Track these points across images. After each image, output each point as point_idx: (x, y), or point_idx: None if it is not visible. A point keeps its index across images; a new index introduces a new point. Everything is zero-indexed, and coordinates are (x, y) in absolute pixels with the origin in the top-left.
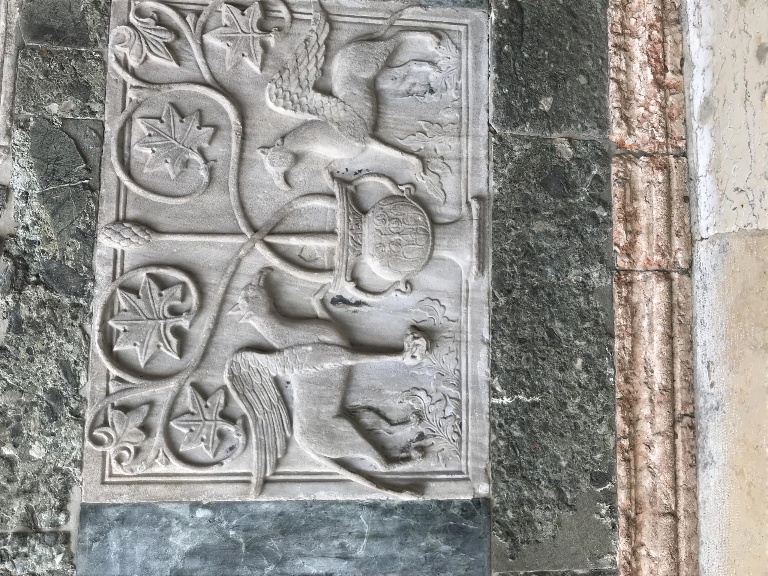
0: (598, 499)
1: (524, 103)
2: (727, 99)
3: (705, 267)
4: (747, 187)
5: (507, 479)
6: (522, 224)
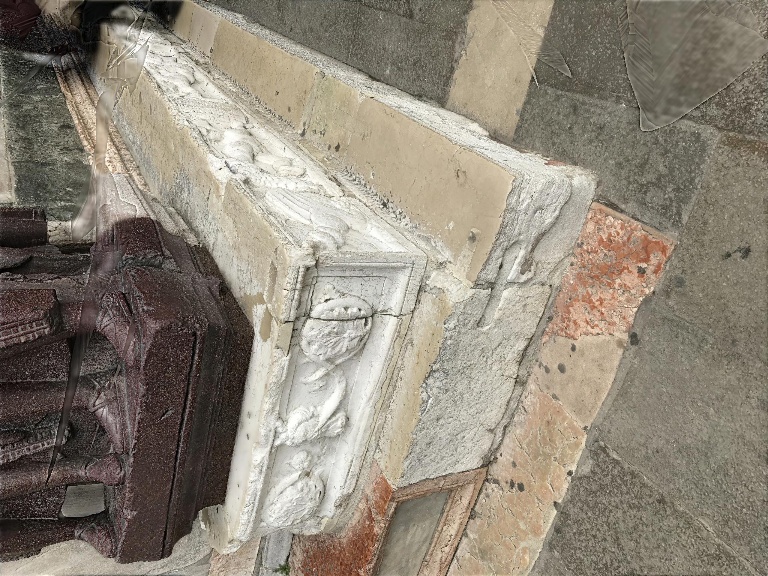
0: (40, 51)
1: (6, 19)
2: (64, 8)
3: (69, 30)
4: (67, 5)
5: (4, 45)
6: (7, 28)
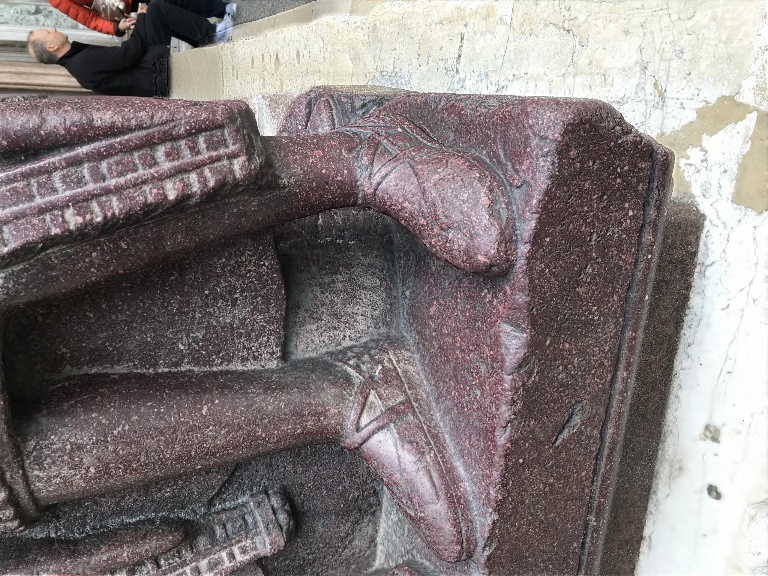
0: None
1: None
2: None
3: None
4: None
5: None
6: None
